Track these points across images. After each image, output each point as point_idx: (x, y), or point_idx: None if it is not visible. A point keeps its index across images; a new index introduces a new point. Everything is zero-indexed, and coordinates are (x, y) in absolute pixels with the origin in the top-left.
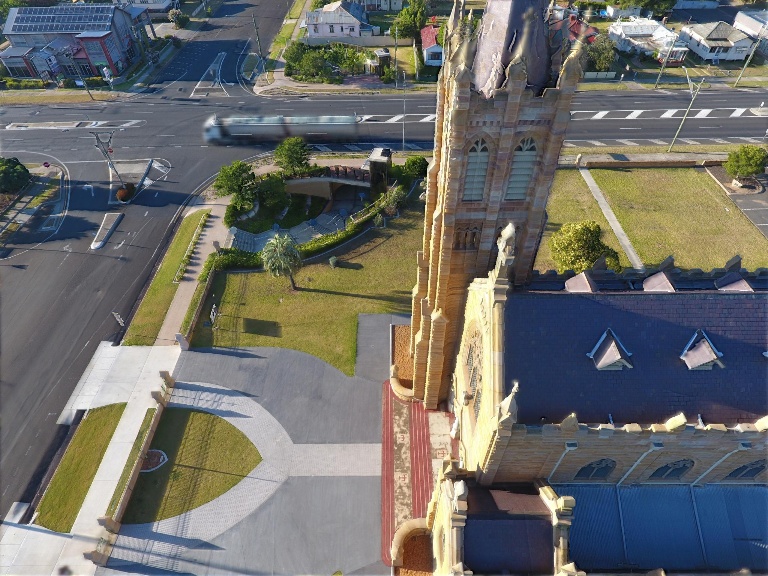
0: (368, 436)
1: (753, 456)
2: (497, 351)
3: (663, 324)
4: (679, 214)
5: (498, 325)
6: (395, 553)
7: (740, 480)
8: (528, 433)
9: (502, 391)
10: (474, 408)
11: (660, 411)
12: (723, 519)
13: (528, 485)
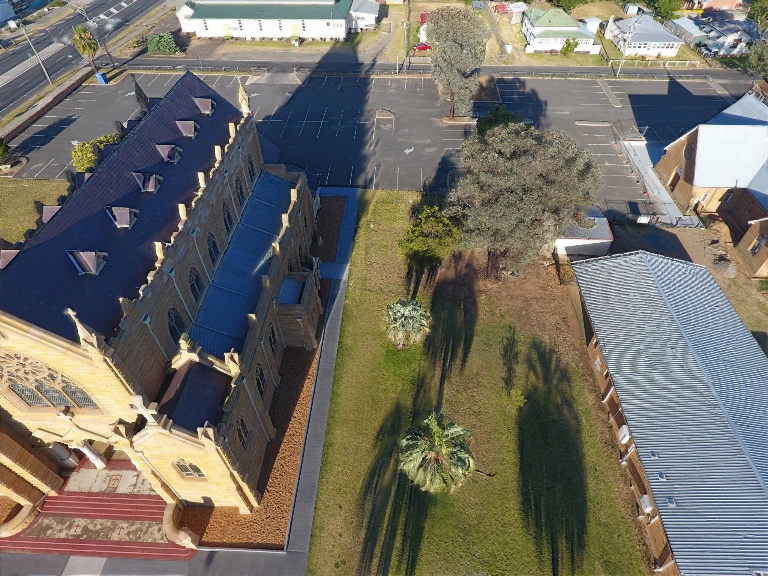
0: (52, 575)
1: (203, 238)
2: (30, 328)
3: (86, 221)
4: (1, 214)
5: (3, 315)
6: (184, 535)
7: (218, 259)
8: (120, 339)
9: (72, 342)
10: (80, 407)
11: (150, 259)
12: (236, 279)
13: (167, 378)
